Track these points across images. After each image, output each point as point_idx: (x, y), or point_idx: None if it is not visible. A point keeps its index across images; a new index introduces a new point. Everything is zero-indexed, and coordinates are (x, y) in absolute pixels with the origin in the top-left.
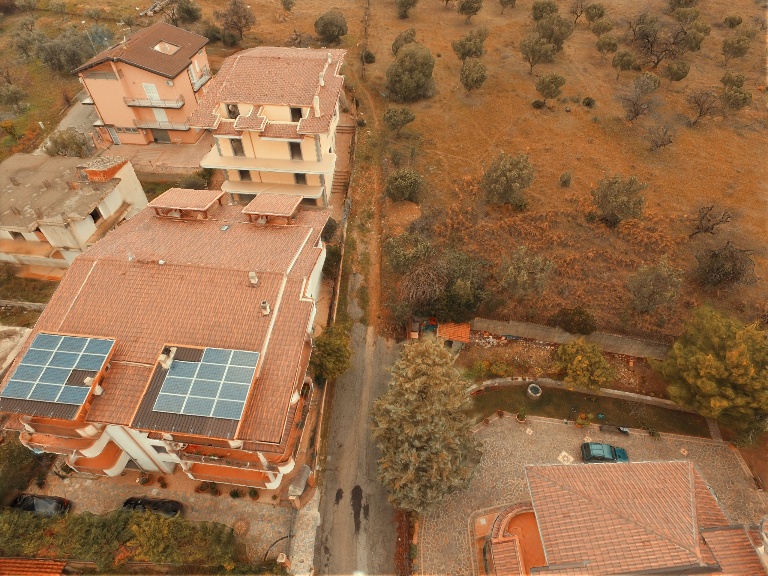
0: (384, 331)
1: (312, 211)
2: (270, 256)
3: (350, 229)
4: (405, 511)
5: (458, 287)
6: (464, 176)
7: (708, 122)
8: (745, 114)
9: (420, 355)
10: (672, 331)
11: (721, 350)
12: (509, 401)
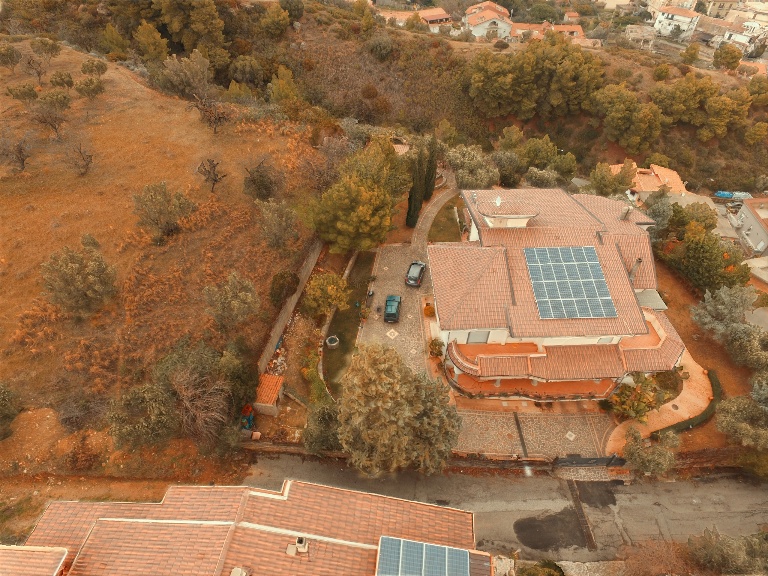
0: (235, 478)
1: (29, 537)
2: (175, 568)
3: (3, 535)
4: (450, 454)
5: (228, 364)
6: (5, 340)
7: (65, 131)
8: (70, 111)
9: (373, 366)
10: (304, 234)
11: (352, 203)
12: (339, 364)
